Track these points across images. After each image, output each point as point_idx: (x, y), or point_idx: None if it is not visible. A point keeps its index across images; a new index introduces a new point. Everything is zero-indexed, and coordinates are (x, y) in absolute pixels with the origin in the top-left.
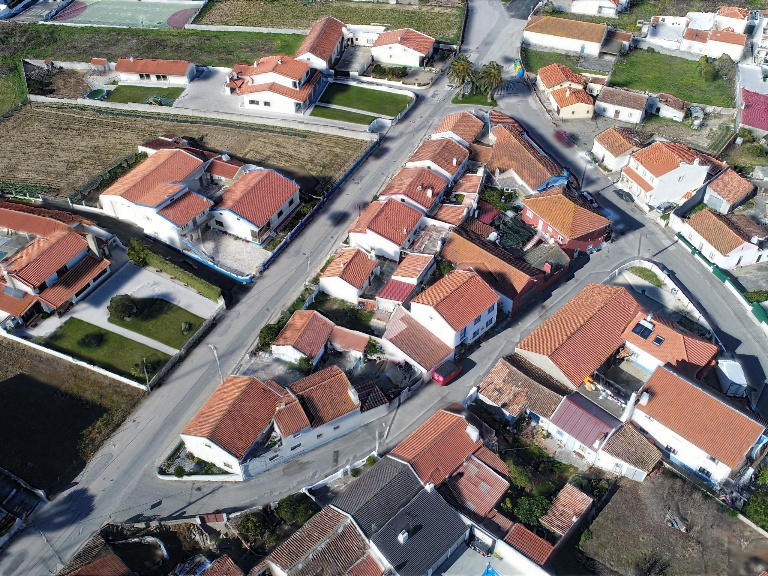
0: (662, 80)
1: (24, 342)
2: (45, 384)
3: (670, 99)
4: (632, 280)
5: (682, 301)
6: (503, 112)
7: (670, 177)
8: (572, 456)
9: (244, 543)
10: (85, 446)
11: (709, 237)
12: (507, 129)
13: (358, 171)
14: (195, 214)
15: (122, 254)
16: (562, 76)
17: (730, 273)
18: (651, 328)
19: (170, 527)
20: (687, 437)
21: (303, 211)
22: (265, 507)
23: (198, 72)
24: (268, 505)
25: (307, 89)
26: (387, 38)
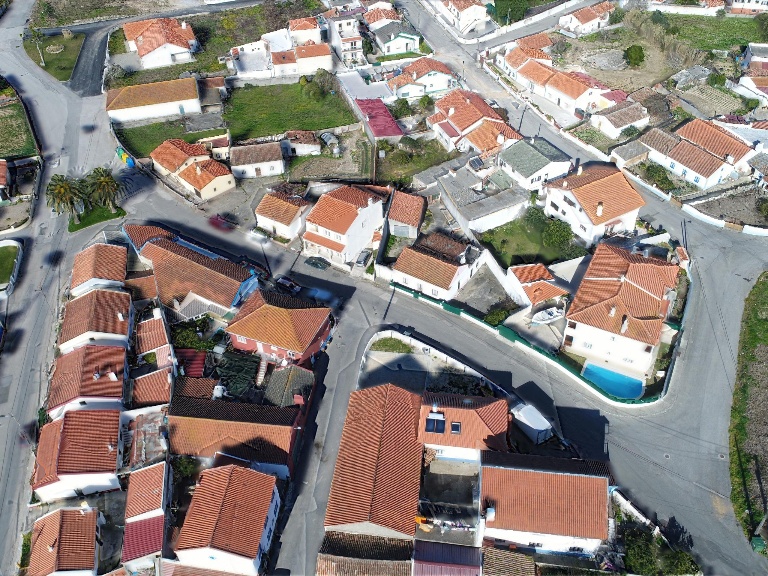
0: (278, 116)
1: None
2: None
3: (299, 135)
4: (382, 359)
5: (439, 358)
6: (137, 219)
7: (354, 228)
8: None
9: None
10: None
11: (424, 276)
12: (158, 245)
13: None
14: None
15: None
16: (181, 153)
17: (458, 301)
18: (442, 419)
19: None
20: (550, 531)
21: None
22: None
23: None
24: None
25: None
26: None
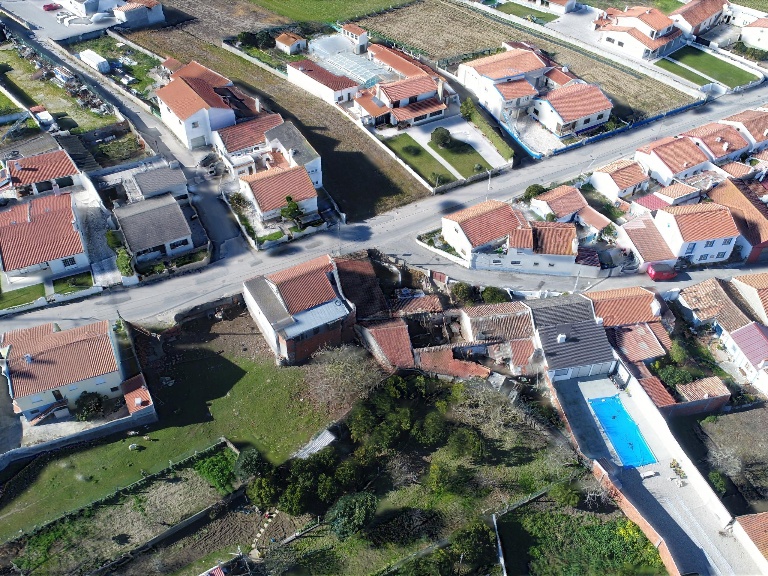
0: None
1: (370, 135)
2: (372, 163)
3: None
4: None
5: None
6: None
7: None
8: (736, 370)
9: (451, 300)
10: (380, 205)
11: None
12: None
13: (672, 117)
14: (521, 95)
15: (457, 108)
16: None
17: None
18: None
19: (410, 270)
20: None
21: (607, 126)
22: (476, 286)
23: (576, 8)
24: (478, 286)
25: (662, 41)
26: (764, 23)
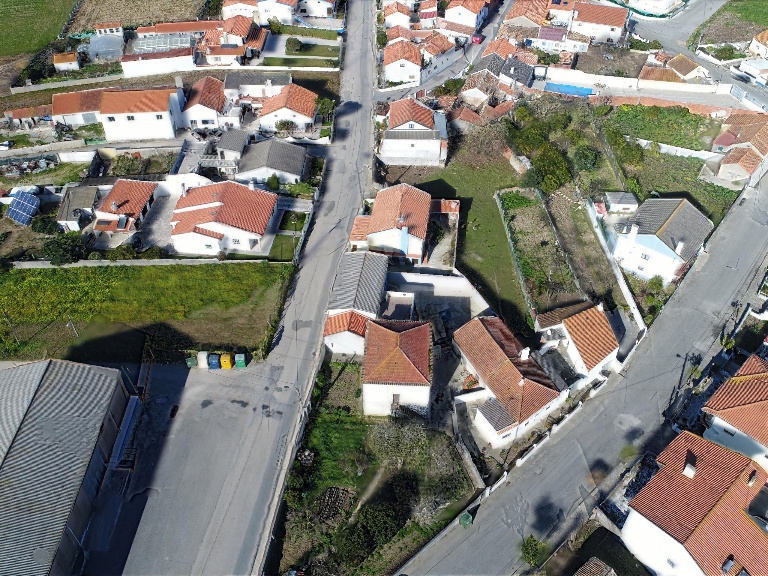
0: None
1: (253, 68)
2: None
3: None
4: None
5: None
6: None
7: None
8: (553, 52)
9: None
10: None
11: None
12: None
13: None
14: (296, 1)
15: None
16: None
17: None
18: None
19: None
20: (600, 23)
21: None
22: None
23: None
24: None
25: None
26: None
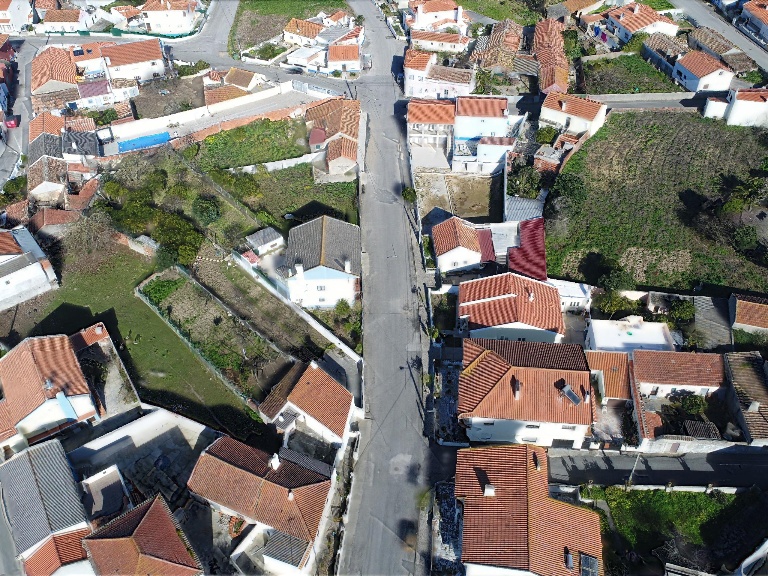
0: None
1: None
2: None
3: None
4: None
5: None
6: None
7: (13, 8)
8: (105, 107)
9: None
10: None
11: (62, 20)
12: None
13: None
14: None
15: None
16: None
17: None
18: (81, 49)
19: None
20: (137, 61)
21: None
22: None
23: None
24: None
25: None
26: None
